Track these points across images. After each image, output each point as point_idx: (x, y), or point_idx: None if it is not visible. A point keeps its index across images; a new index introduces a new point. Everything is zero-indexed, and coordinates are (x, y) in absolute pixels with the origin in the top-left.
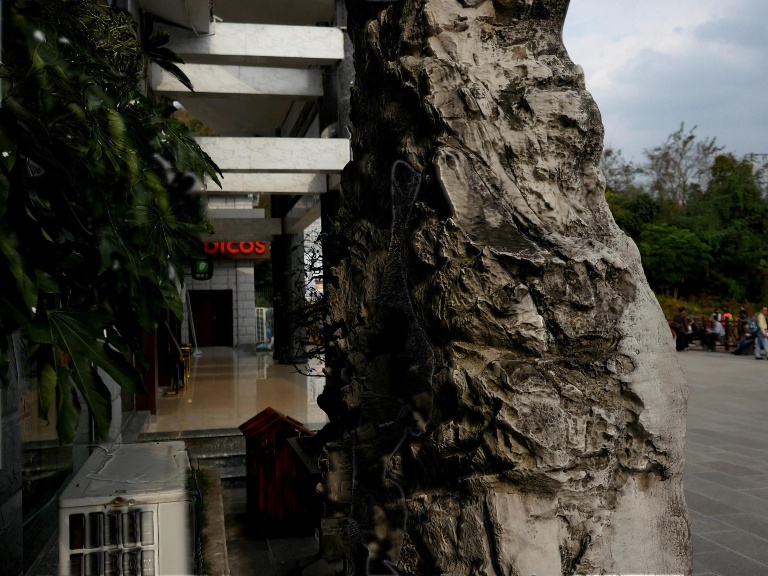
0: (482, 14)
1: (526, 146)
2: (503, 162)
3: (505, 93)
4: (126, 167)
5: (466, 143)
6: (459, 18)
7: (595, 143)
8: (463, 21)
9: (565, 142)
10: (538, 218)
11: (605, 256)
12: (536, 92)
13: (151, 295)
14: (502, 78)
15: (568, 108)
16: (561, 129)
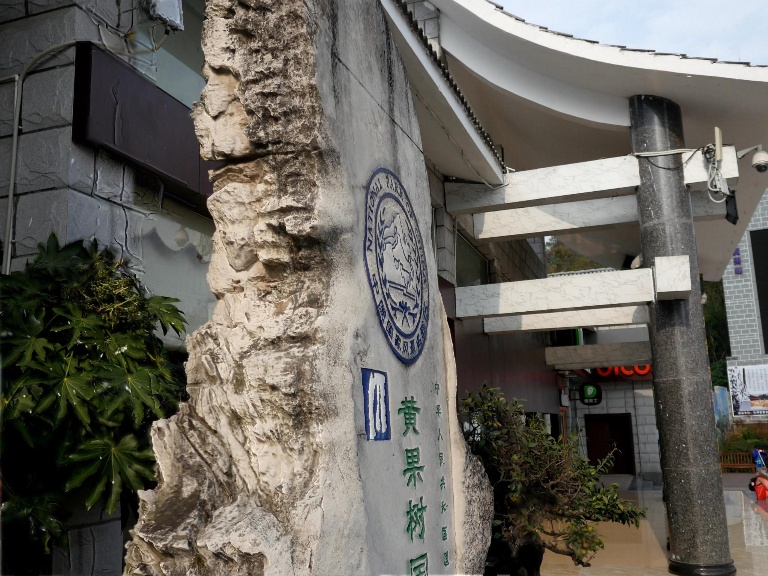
0: (253, 275)
1: (247, 409)
2: (232, 424)
3: (245, 355)
4: (75, 413)
5: (196, 409)
6: (234, 282)
7: (308, 403)
8: (238, 284)
9: (275, 404)
10: (257, 481)
11: (231, 540)
12: (254, 356)
13: (15, 534)
14: (246, 340)
15: (269, 372)
16: (270, 392)
